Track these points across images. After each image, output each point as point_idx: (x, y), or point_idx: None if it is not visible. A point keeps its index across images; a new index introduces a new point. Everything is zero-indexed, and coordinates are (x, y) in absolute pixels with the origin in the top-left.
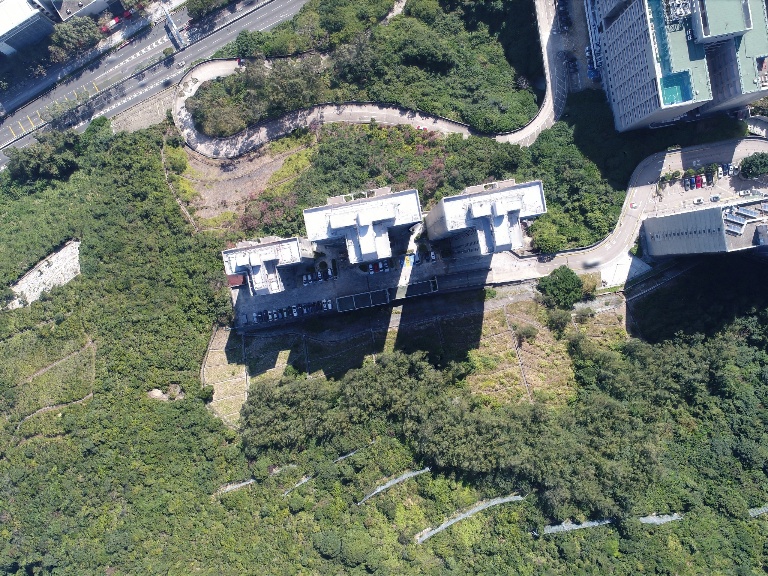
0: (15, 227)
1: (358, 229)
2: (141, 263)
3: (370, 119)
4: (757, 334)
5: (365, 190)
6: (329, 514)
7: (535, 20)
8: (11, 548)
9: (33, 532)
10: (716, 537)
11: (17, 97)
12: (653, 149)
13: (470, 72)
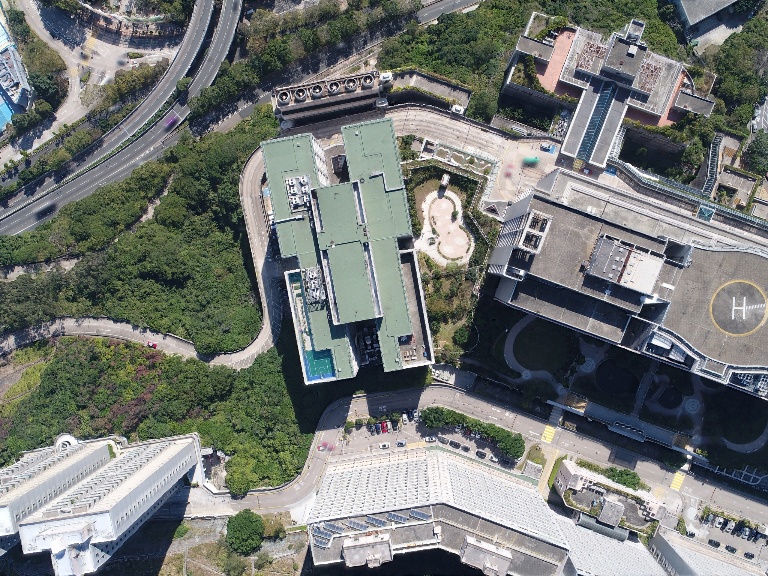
0: None
1: None
2: None
3: (106, 332)
4: None
5: (67, 426)
6: None
7: None
8: None
9: None
10: None
11: None
12: (342, 392)
13: (204, 285)
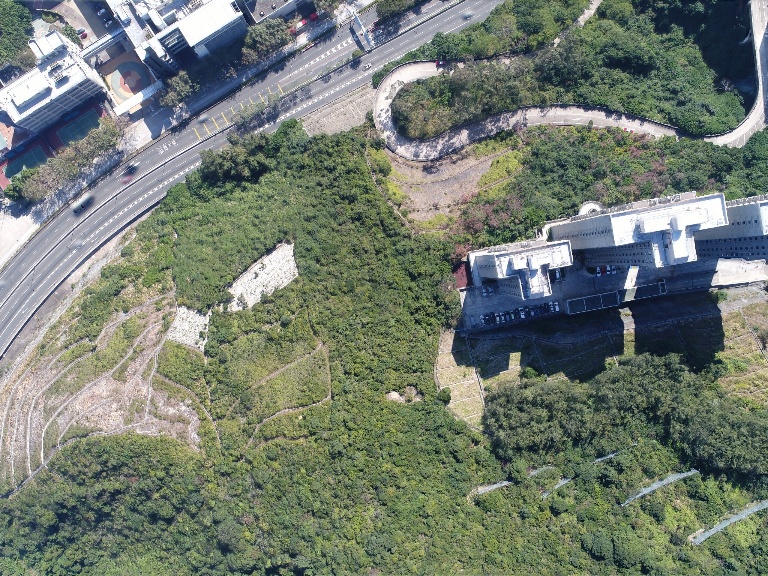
0: (216, 229)
1: (671, 233)
2: (359, 265)
3: (575, 121)
4: None
5: (594, 193)
6: (594, 515)
7: (739, 22)
8: (253, 550)
9: (281, 534)
10: None
11: (202, 99)
12: None
13: (672, 74)
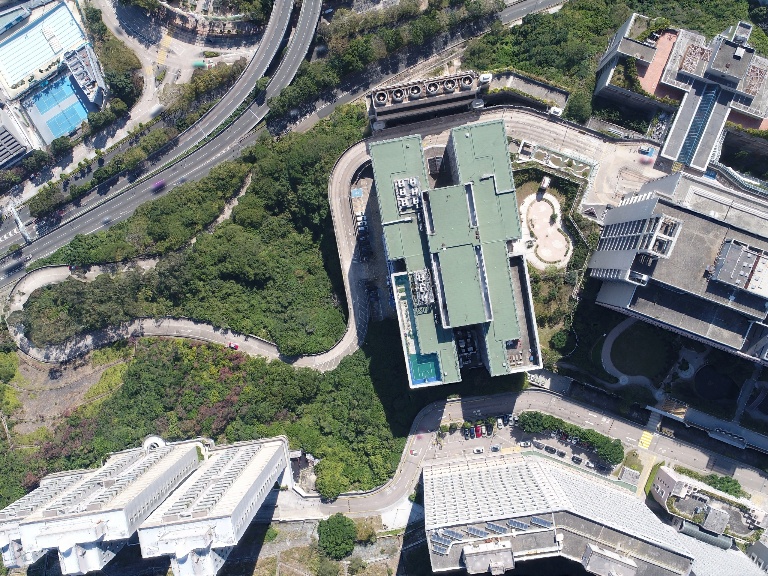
0: None
1: None
2: None
3: (186, 333)
4: None
5: (155, 428)
6: None
7: None
8: None
9: None
10: None
11: None
12: (435, 396)
13: (285, 287)
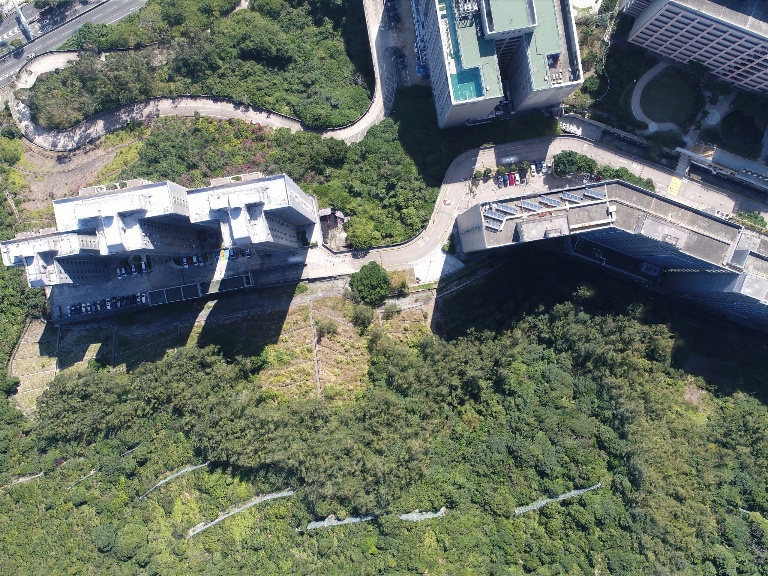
0: None
1: (103, 220)
2: None
3: (205, 113)
4: (546, 332)
5: (179, 183)
6: (110, 508)
7: None
8: None
9: None
10: (474, 534)
11: None
12: (468, 146)
13: (307, 67)
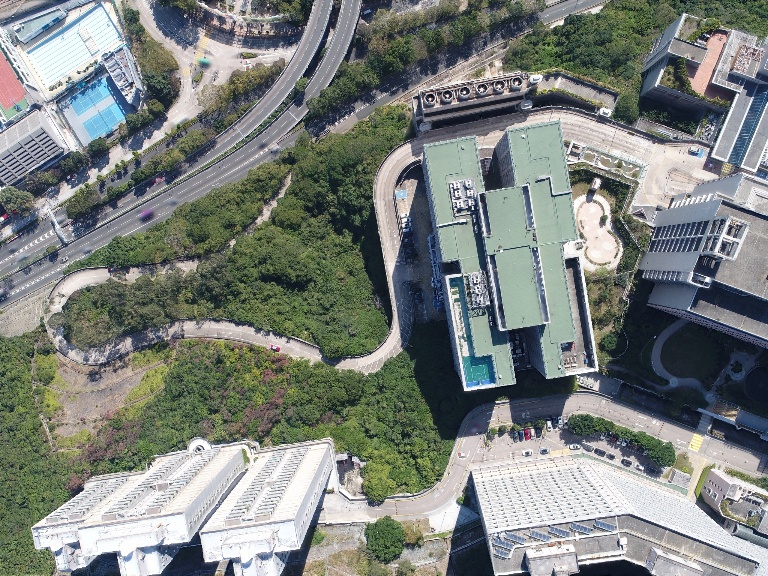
0: None
1: None
2: (1, 481)
3: (227, 335)
4: None
5: (200, 430)
6: None
7: None
8: None
9: None
10: None
11: None
12: (483, 398)
13: (326, 289)
